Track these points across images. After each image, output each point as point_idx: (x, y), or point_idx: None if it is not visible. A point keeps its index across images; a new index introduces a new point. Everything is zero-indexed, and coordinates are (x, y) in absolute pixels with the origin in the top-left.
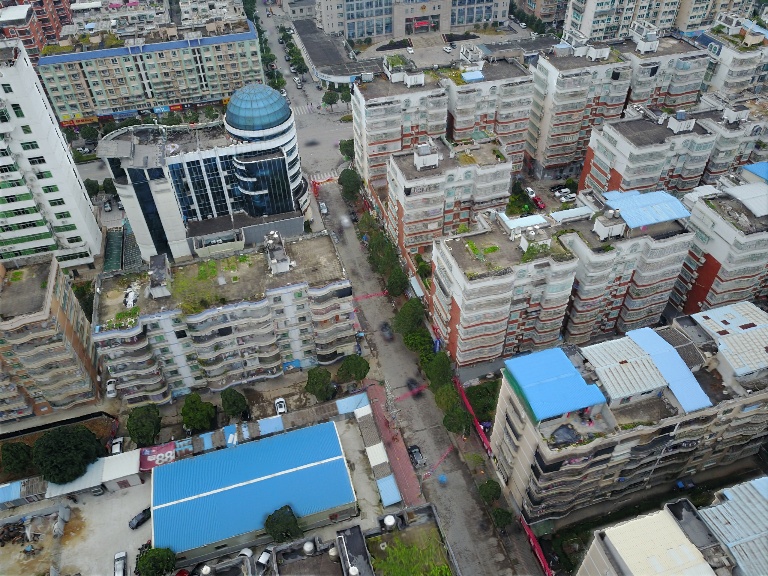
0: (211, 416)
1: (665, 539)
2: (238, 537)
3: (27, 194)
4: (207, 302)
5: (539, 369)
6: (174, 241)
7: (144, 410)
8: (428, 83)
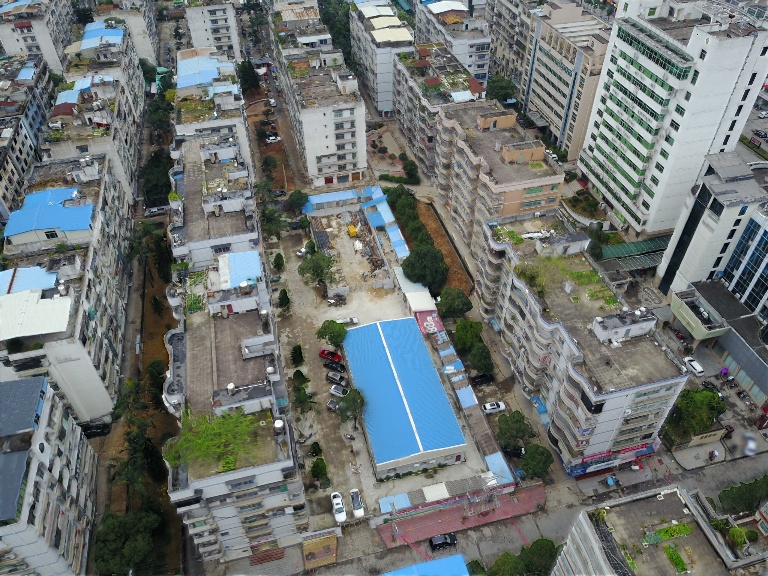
0: (466, 346)
1: None
2: (352, 380)
3: (649, 143)
4: (534, 281)
5: None
6: (682, 275)
7: (456, 293)
8: None
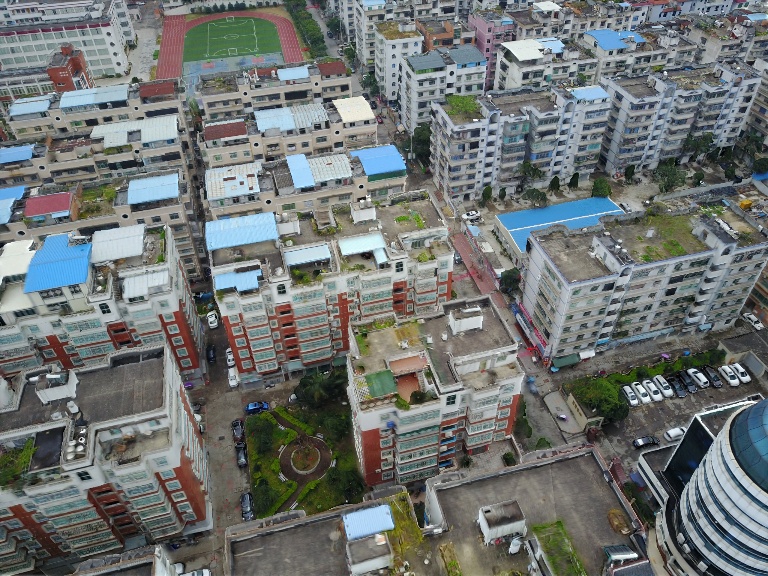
0: None
1: (350, 114)
2: None
3: None
4: None
5: (385, 162)
6: None
7: None
8: (469, 535)
